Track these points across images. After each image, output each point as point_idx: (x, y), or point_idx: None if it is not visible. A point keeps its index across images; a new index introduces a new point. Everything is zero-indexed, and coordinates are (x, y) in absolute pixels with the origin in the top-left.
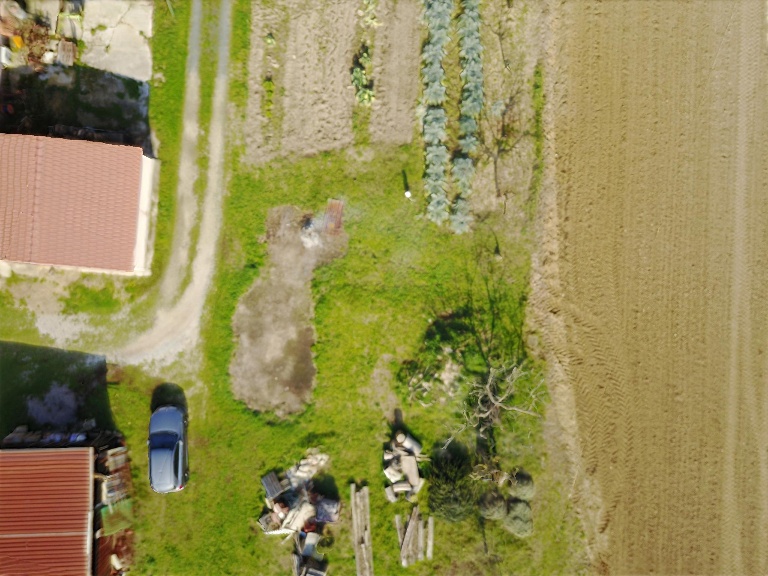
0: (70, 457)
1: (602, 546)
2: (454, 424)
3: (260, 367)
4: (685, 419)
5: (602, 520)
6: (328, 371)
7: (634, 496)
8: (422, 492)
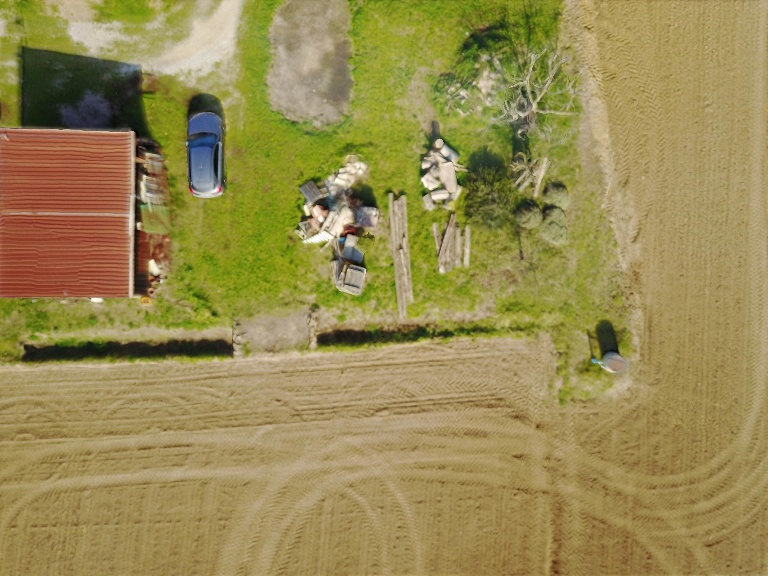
0: (111, 142)
1: (634, 255)
2: (491, 136)
3: (298, 79)
4: (715, 129)
5: (634, 229)
6: (366, 83)
7: (665, 204)
8: (459, 202)
